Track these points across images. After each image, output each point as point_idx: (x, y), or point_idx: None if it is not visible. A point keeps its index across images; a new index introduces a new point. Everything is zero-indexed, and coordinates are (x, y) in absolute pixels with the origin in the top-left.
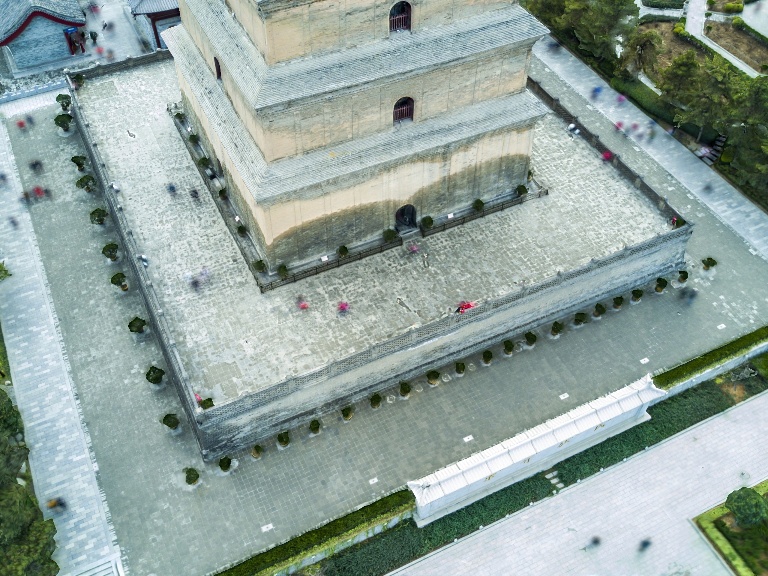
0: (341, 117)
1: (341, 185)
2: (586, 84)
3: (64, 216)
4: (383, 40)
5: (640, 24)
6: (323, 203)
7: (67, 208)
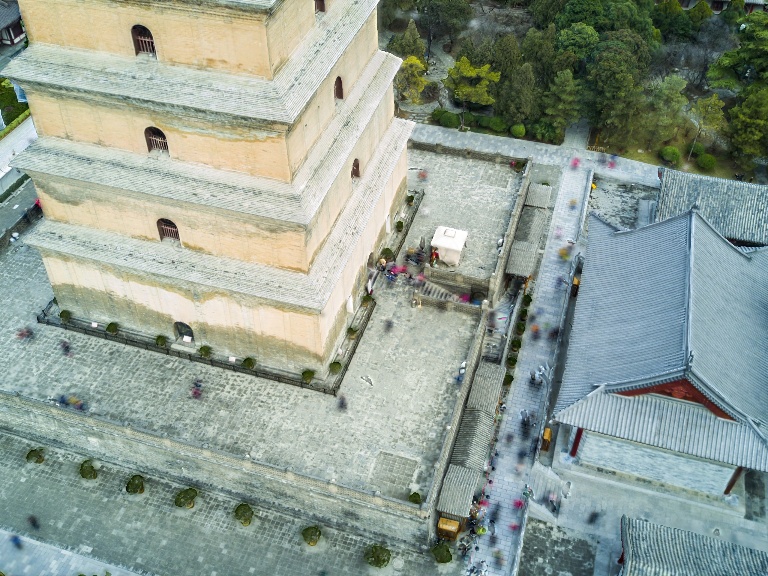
0: None
1: None
2: None
3: None
4: None
5: None
6: None
7: None
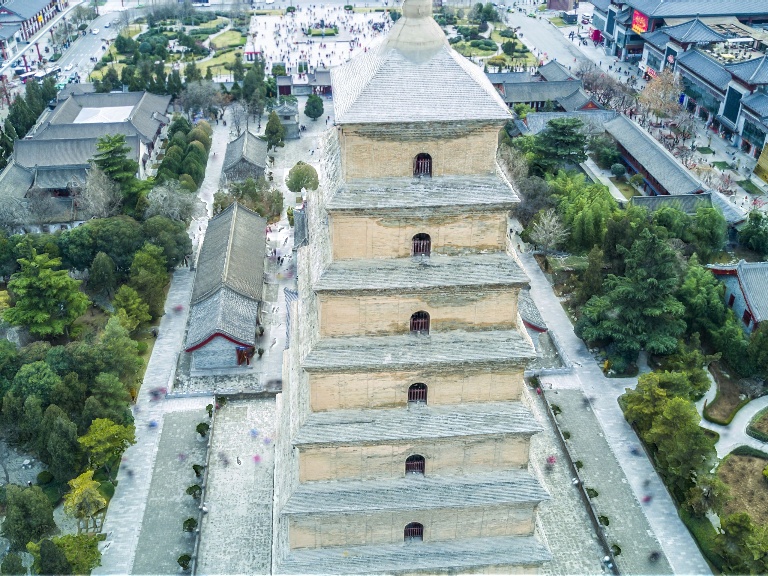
0: (357, 527)
1: None
2: (656, 506)
3: (168, 515)
4: (399, 478)
5: (734, 454)
6: None
7: (174, 508)
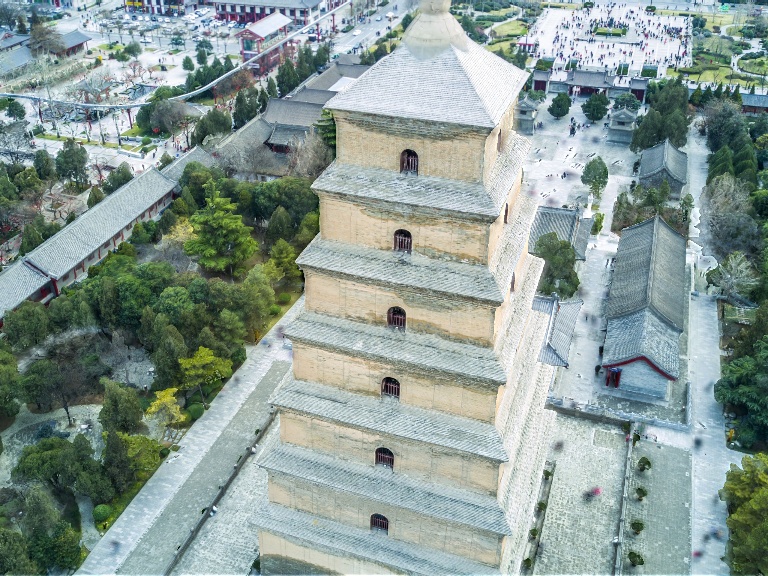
0: (327, 501)
1: (318, 547)
2: None
3: (234, 447)
4: (370, 466)
5: None
6: (304, 552)
7: (241, 443)
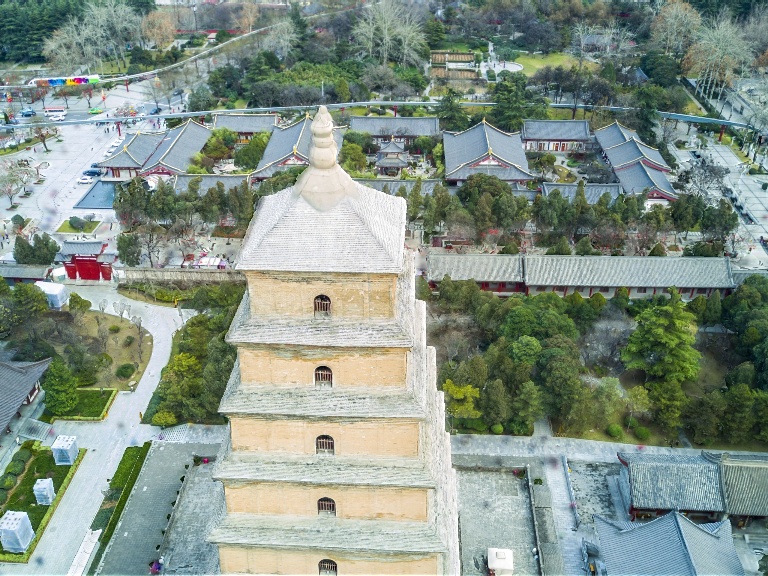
0: None
1: None
2: None
3: None
4: None
5: None
6: None
7: None
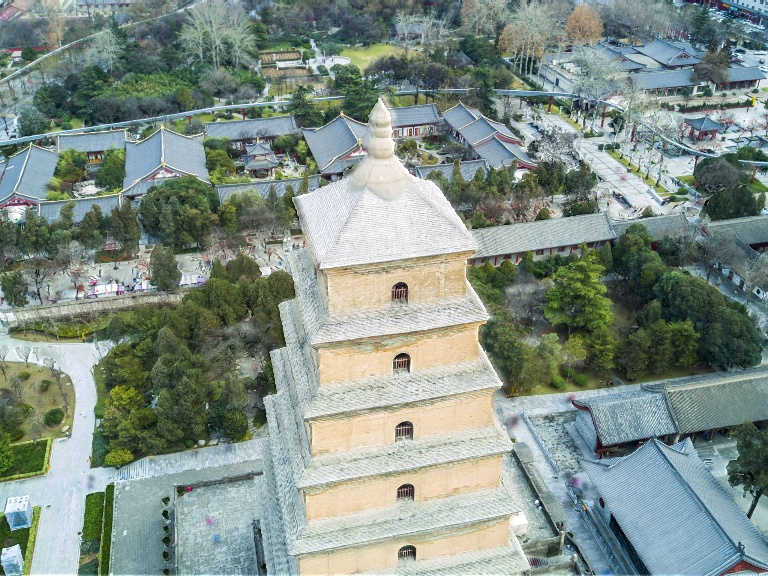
0: None
1: None
2: None
3: None
4: None
5: None
6: None
7: None
